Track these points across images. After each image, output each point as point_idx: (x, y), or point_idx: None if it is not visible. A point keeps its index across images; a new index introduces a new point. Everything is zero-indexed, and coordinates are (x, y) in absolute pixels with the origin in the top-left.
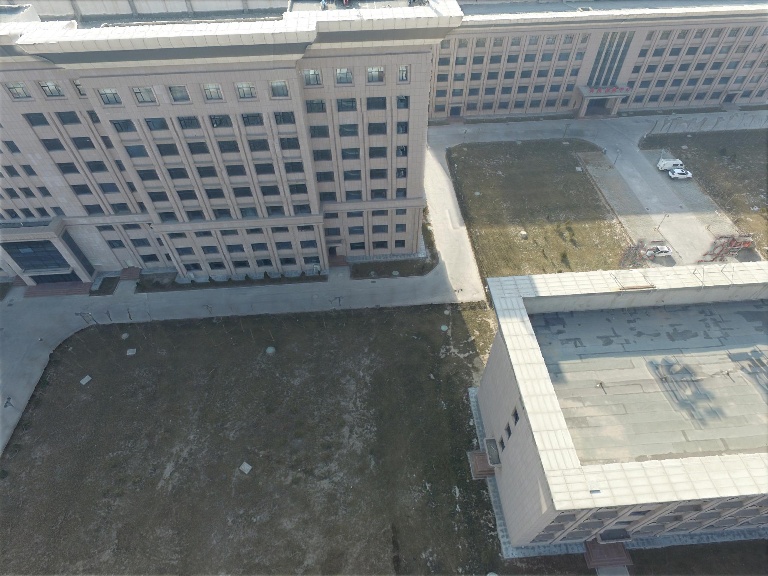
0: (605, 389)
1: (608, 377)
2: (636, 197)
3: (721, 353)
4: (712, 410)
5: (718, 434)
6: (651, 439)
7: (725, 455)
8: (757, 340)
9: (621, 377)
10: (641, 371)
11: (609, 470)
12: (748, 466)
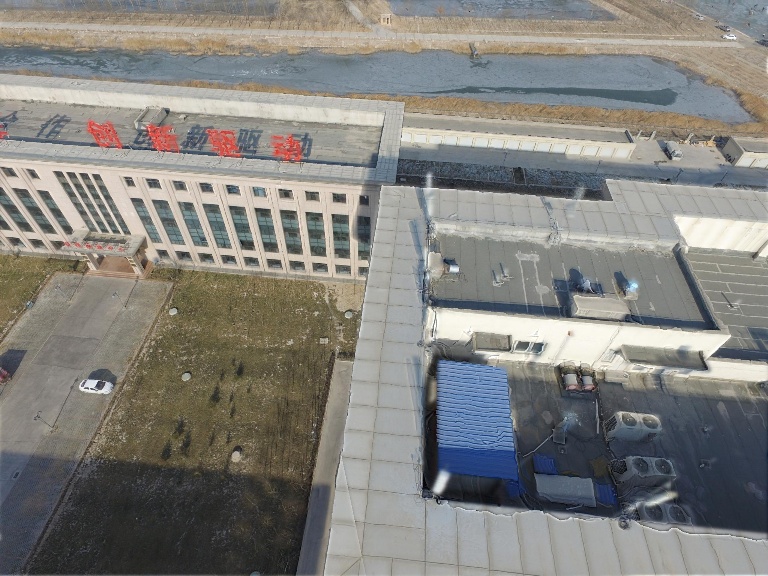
0: (343, 150)
1: (337, 154)
2: (2, 507)
3: (258, 155)
4: (293, 137)
5: (300, 130)
6: (335, 133)
7: (318, 105)
8: (229, 156)
9: (330, 152)
10: (315, 153)
11: (375, 107)
12: (312, 101)
